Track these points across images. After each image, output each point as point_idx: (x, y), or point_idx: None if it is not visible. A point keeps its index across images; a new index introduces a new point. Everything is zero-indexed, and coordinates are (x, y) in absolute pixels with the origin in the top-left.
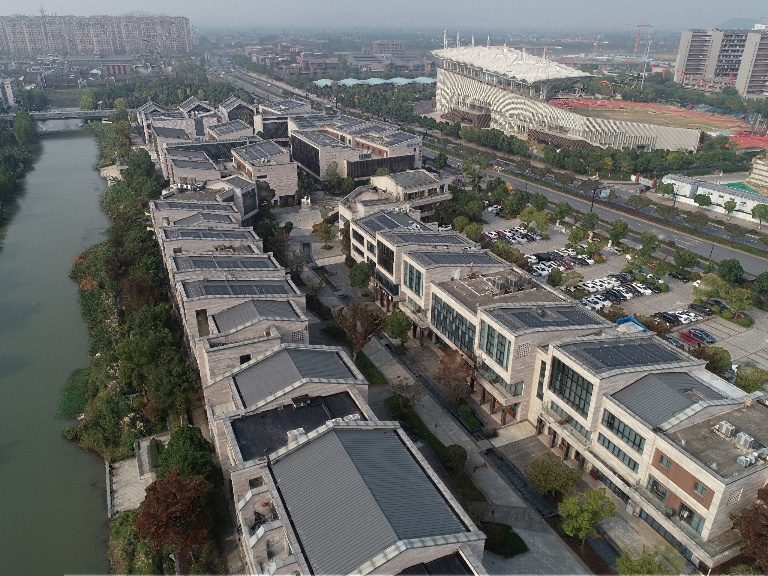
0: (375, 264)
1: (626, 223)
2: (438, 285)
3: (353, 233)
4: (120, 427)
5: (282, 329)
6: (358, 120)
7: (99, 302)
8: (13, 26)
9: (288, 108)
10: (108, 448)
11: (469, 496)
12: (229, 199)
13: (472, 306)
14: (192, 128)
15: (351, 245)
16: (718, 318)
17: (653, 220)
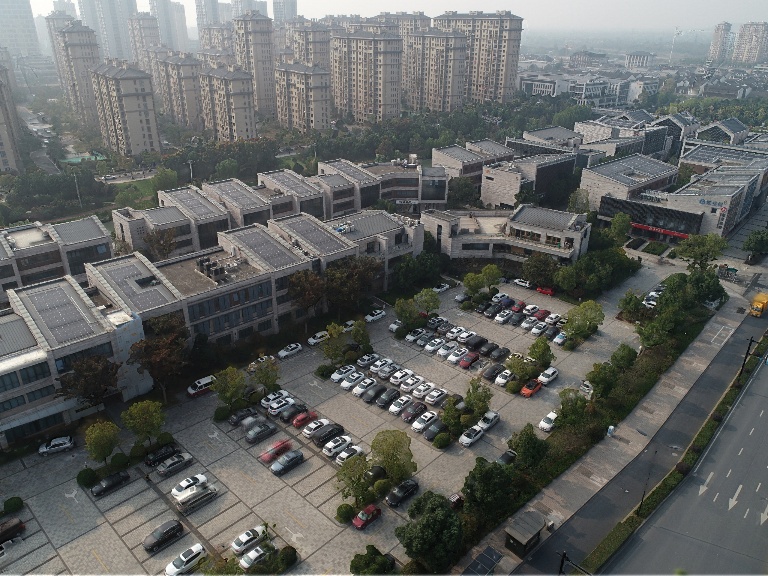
0: None
1: (613, 376)
2: None
3: None
4: None
5: (147, 223)
6: (766, 166)
7: None
8: (679, 33)
9: (767, 141)
10: None
11: None
12: (413, 181)
13: (179, 264)
14: (608, 137)
15: None
16: None
17: None
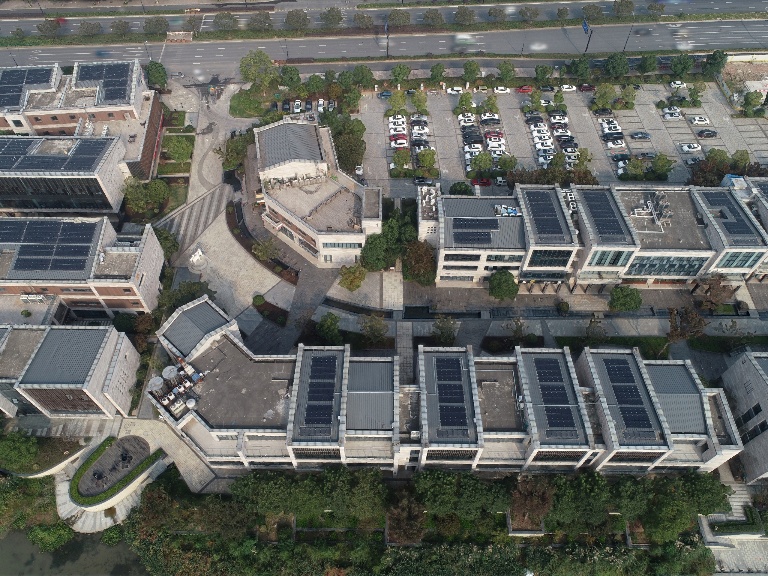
0: (506, 267)
1: None
2: (645, 249)
3: (444, 257)
4: (683, 557)
5: None
6: None
7: (402, 568)
8: None
9: None
10: (700, 572)
11: None
12: None
13: (681, 245)
14: None
15: (440, 268)
16: (615, 112)
17: (425, 31)
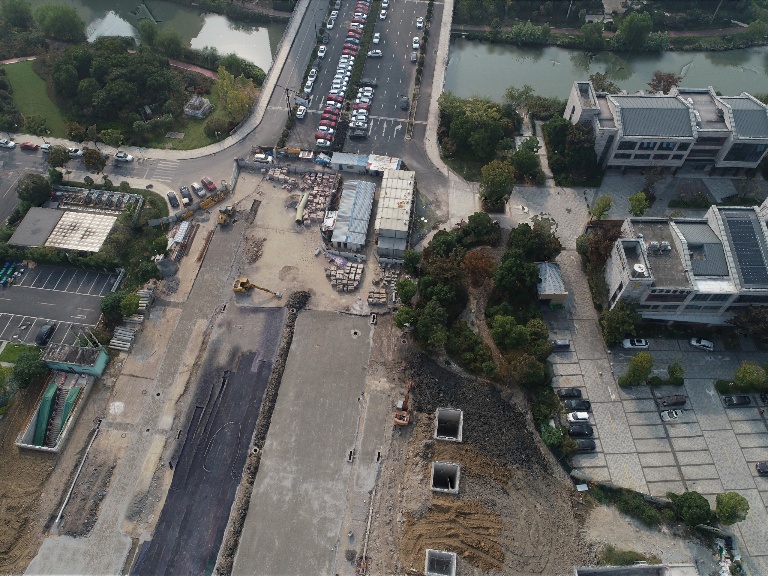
0: None
1: None
2: None
3: None
4: None
5: None
6: None
7: None
8: None
9: None
10: None
11: (672, 201)
12: None
13: None
14: None
15: None
16: None
17: None
